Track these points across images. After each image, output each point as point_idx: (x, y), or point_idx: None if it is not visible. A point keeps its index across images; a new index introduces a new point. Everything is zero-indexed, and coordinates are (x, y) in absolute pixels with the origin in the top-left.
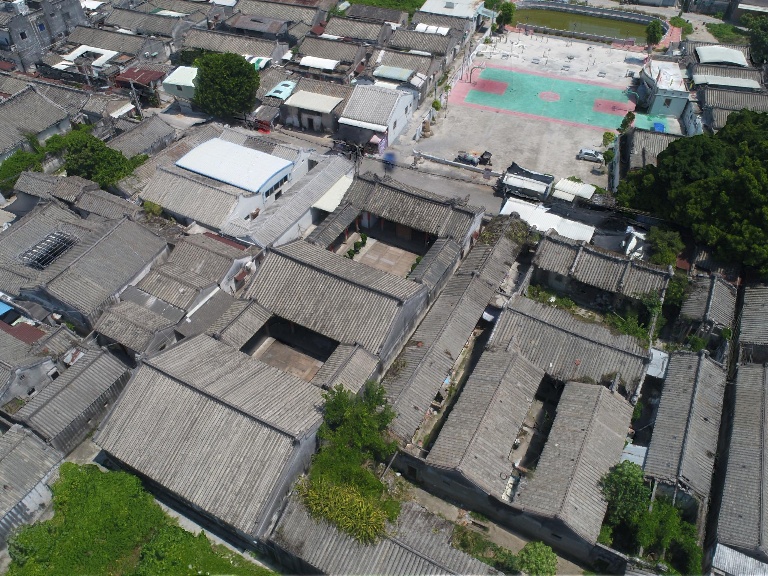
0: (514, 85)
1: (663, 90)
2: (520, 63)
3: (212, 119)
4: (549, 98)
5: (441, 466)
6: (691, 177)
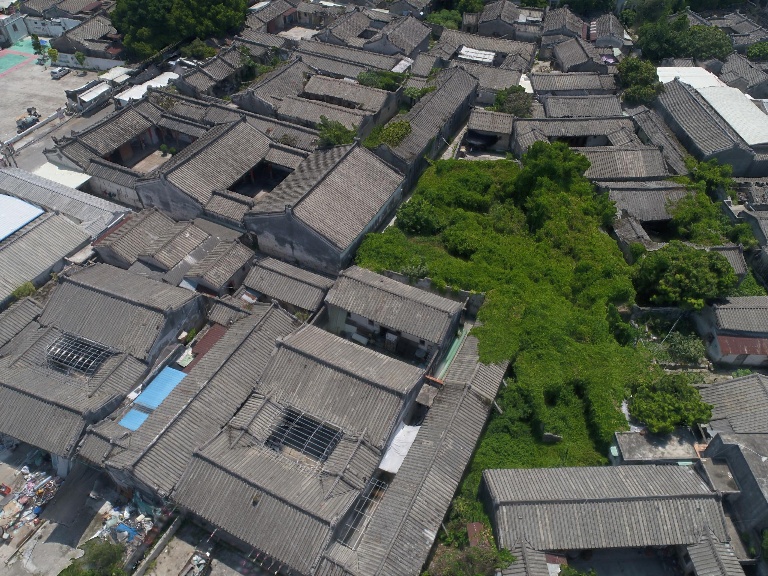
0: None
1: (5, 19)
2: None
3: None
4: None
5: (360, 123)
6: (170, 6)
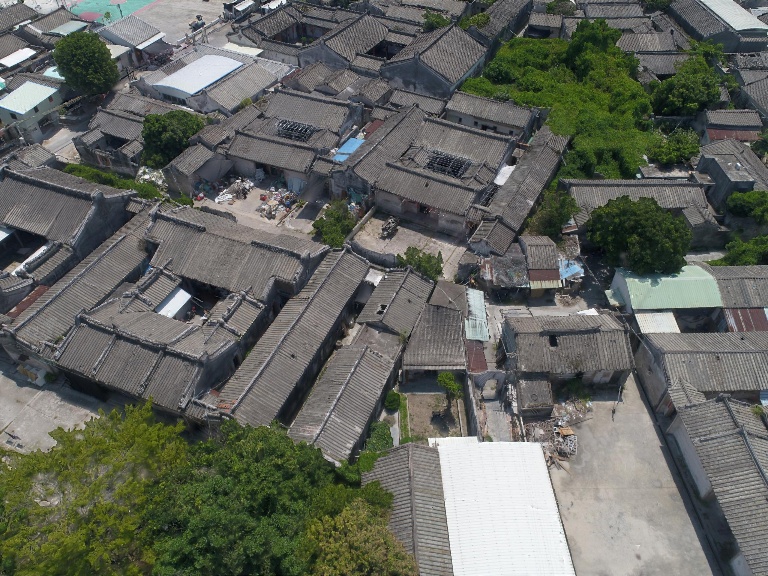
0: (91, 10)
1: None
2: (53, 5)
3: (108, 95)
4: (120, 1)
5: None
6: None
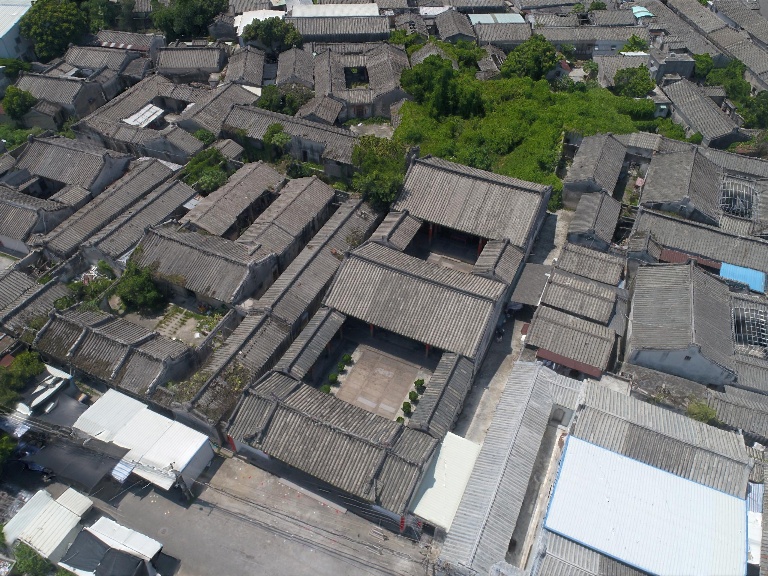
0: None
1: None
2: None
3: None
4: None
5: None
6: None
